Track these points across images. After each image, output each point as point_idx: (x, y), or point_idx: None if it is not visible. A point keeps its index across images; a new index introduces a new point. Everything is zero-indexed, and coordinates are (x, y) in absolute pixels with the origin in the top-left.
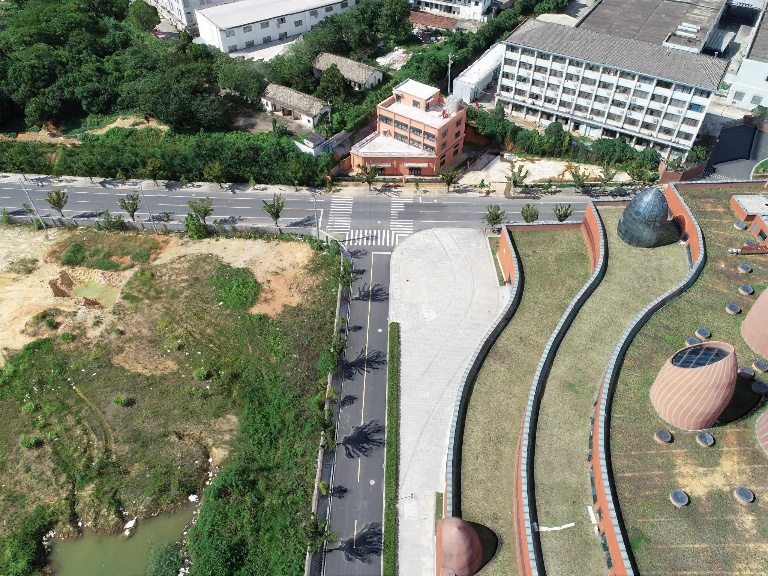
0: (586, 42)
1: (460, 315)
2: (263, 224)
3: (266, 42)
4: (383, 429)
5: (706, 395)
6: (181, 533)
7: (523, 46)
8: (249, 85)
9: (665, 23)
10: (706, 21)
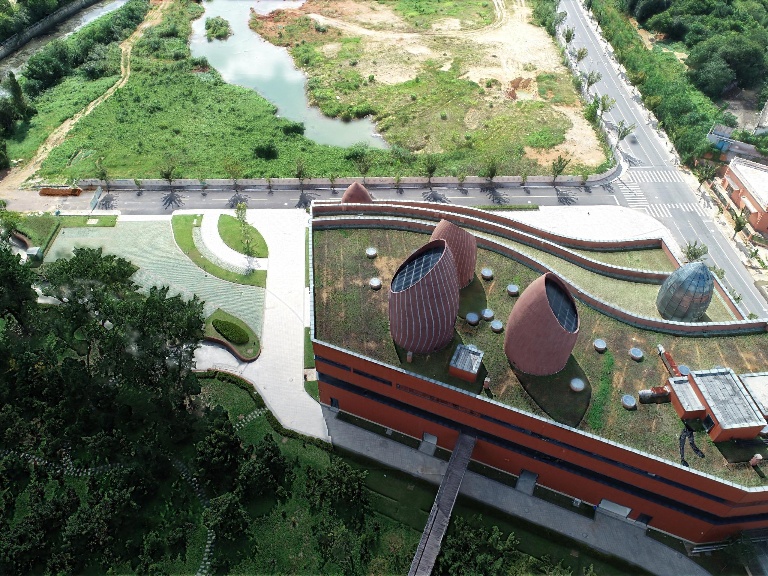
0: None
1: None
2: None
3: None
4: None
5: None
6: None
7: None
8: None
9: None
10: None
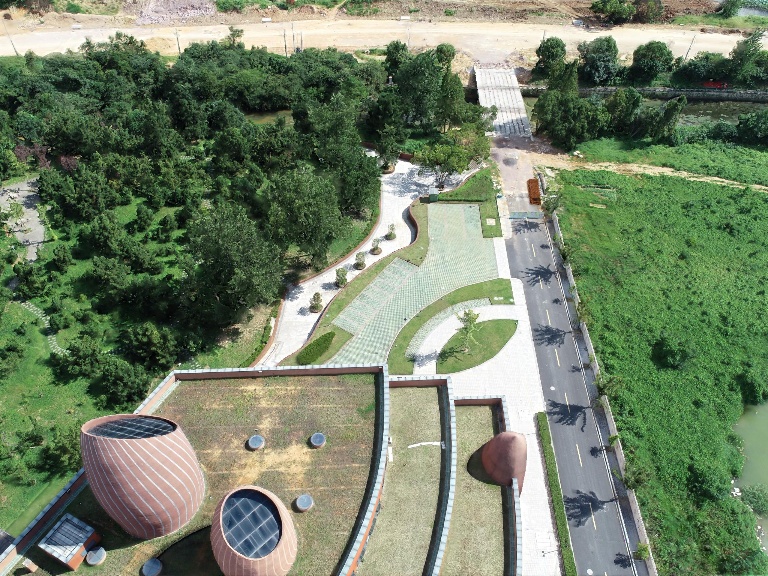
0: None
1: None
2: None
3: None
4: None
5: None
6: (763, 527)
7: None
8: None
9: None
10: None
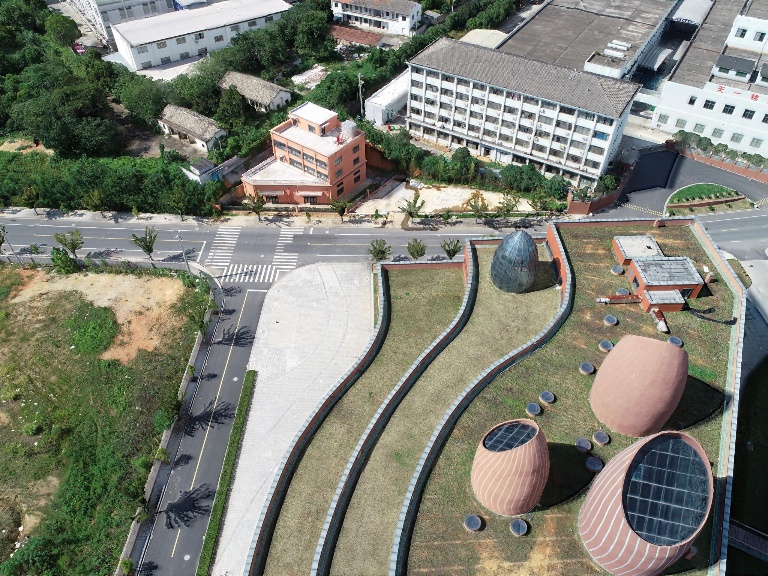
0: (491, 64)
1: (324, 362)
2: (139, 257)
3: (184, 58)
4: (213, 494)
5: (510, 482)
6: None
7: (427, 68)
8: (144, 107)
9: (595, 40)
10: (639, 38)
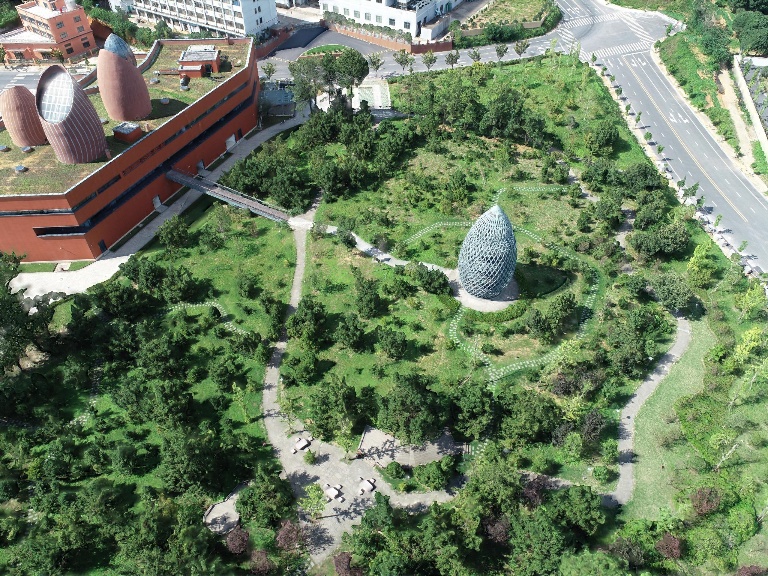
0: None
1: None
2: None
3: None
4: None
5: (8, 116)
6: None
7: None
8: None
9: None
10: None
